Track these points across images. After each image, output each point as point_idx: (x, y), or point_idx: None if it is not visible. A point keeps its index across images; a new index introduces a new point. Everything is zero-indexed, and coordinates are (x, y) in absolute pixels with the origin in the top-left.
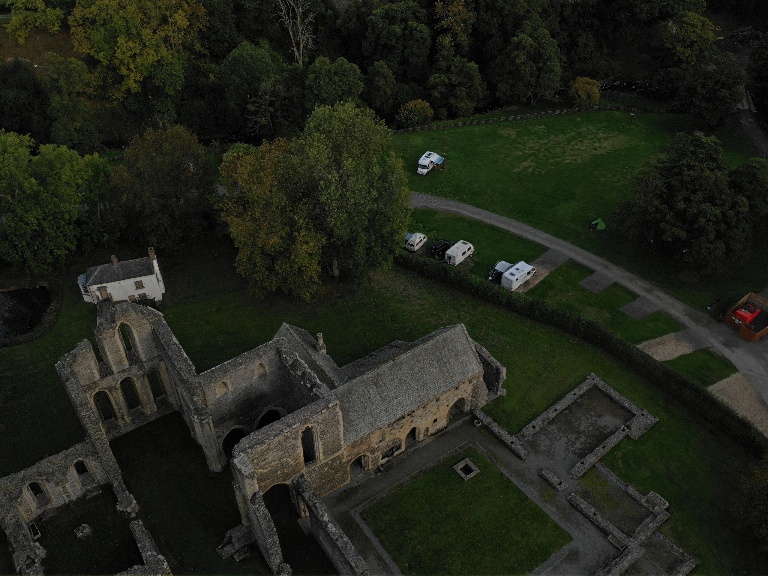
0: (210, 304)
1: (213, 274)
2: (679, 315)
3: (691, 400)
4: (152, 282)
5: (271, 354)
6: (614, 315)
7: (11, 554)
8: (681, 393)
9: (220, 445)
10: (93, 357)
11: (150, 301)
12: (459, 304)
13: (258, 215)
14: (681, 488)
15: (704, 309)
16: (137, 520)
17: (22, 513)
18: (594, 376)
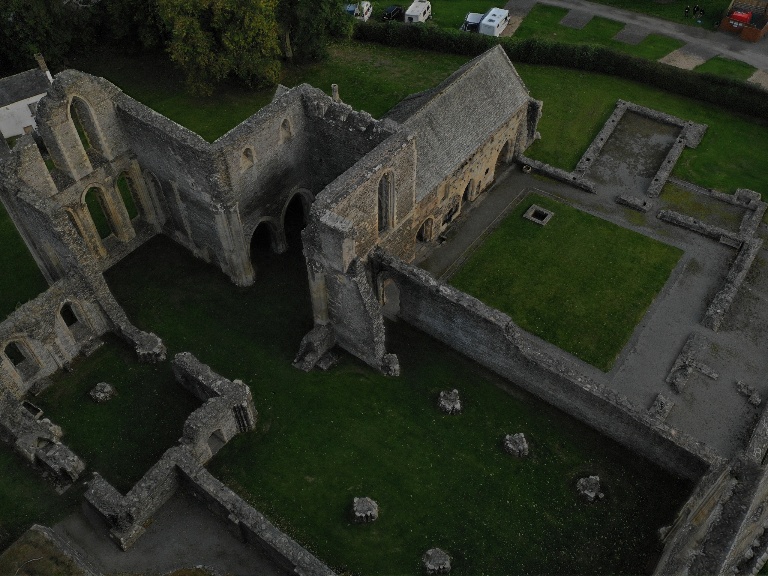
0: None
1: (125, 88)
2: (674, 33)
3: (735, 98)
4: None
5: (295, 106)
6: (610, 45)
7: (10, 445)
8: (722, 94)
9: (247, 247)
10: None
11: None
12: (443, 64)
13: None
14: (763, 180)
15: (695, 23)
16: (180, 353)
17: None
18: (623, 101)
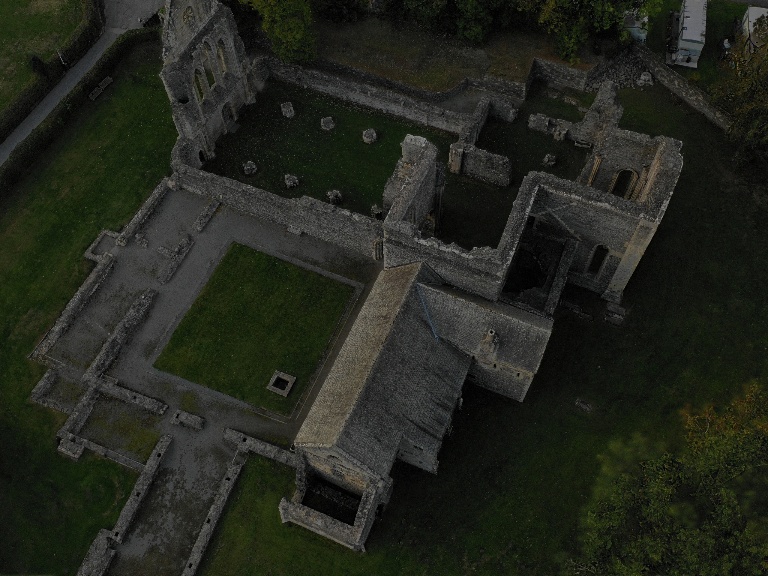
0: None
1: None
2: None
3: None
4: None
5: None
6: None
7: None
8: None
9: None
10: None
11: None
12: None
13: None
14: (44, 482)
15: None
16: None
17: None
18: None
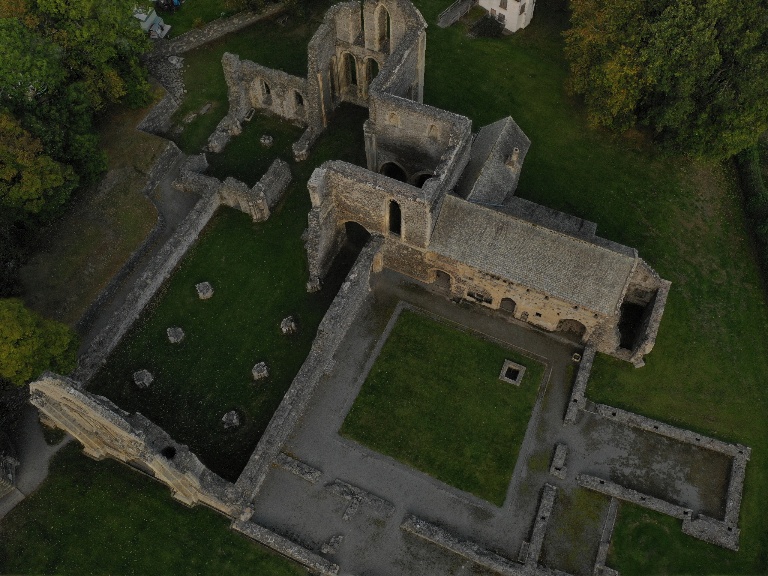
0: (535, 65)
1: None
2: None
3: None
4: (515, 9)
5: (447, 125)
6: None
7: None
8: None
9: (379, 166)
10: (356, 21)
11: (497, 24)
12: (735, 262)
13: (607, 1)
14: None
15: None
16: (283, 161)
17: (252, 96)
18: (747, 451)
